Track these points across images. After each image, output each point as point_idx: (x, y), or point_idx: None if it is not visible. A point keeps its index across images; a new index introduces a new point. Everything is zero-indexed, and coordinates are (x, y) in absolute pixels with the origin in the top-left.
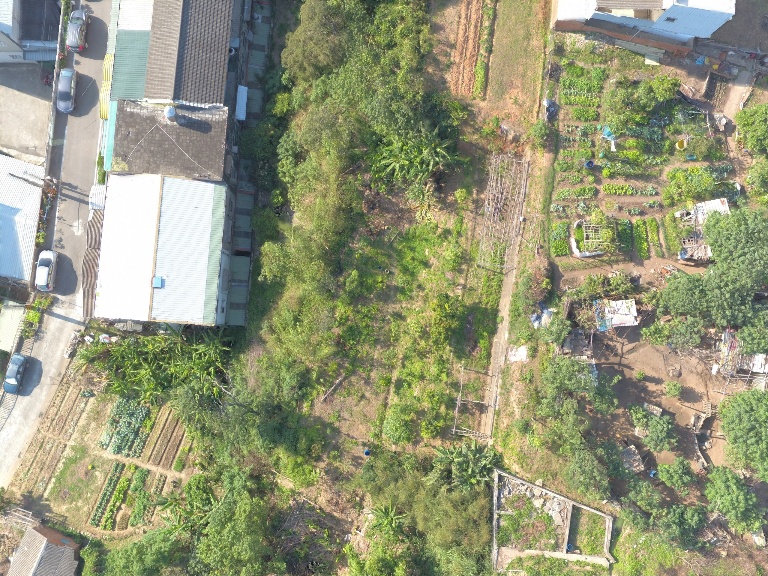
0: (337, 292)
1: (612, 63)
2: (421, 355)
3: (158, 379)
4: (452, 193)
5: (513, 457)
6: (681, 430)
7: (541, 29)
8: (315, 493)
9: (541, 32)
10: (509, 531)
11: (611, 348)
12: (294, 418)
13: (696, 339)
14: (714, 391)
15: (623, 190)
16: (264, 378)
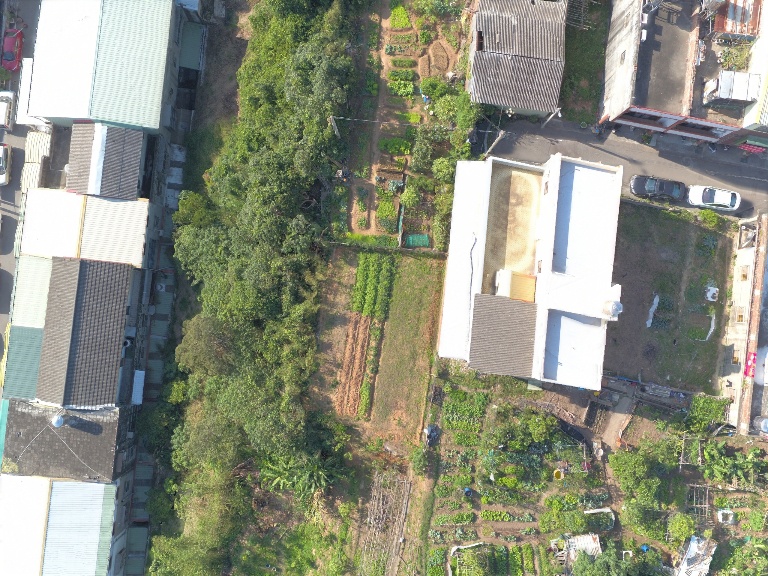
0: None
1: (495, 388)
2: None
3: None
4: (339, 497)
5: None
6: None
7: (427, 349)
8: None
9: (427, 352)
10: None
11: None
12: None
13: None
14: None
15: (501, 517)
16: None
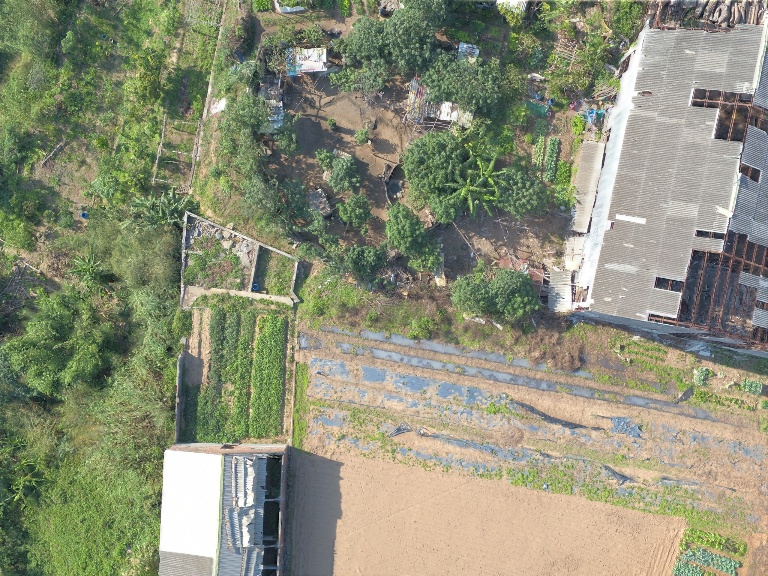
0: (62, 61)
1: None
2: (138, 119)
3: None
4: None
5: (207, 203)
6: (374, 180)
7: None
8: (37, 259)
9: None
10: (196, 270)
11: (309, 101)
12: (13, 181)
13: (379, 82)
14: None
15: None
16: None
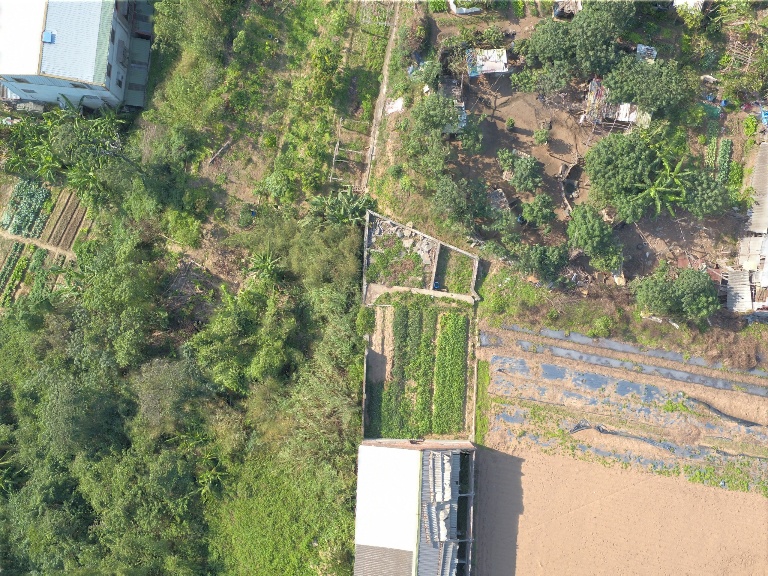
0: (228, 60)
1: None
2: (306, 118)
3: (56, 155)
4: None
5: (386, 202)
6: (549, 180)
7: None
8: (202, 256)
9: None
10: (378, 268)
11: (485, 101)
12: (182, 179)
13: (561, 83)
14: (582, 143)
15: None
16: (157, 148)
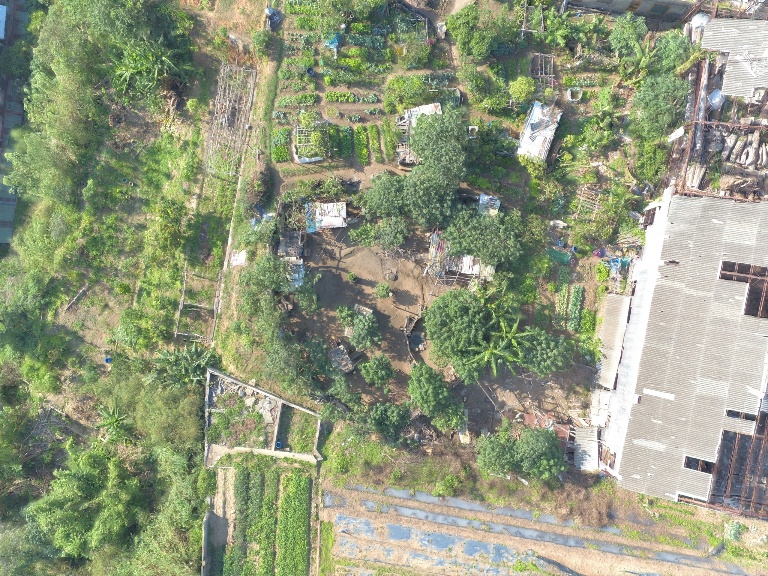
0: (83, 204)
1: None
2: (159, 264)
3: None
4: None
5: (229, 358)
6: (396, 332)
7: None
8: (62, 402)
9: None
10: (219, 429)
11: (329, 252)
12: (38, 327)
13: (399, 239)
14: (429, 294)
15: (345, 97)
16: None
